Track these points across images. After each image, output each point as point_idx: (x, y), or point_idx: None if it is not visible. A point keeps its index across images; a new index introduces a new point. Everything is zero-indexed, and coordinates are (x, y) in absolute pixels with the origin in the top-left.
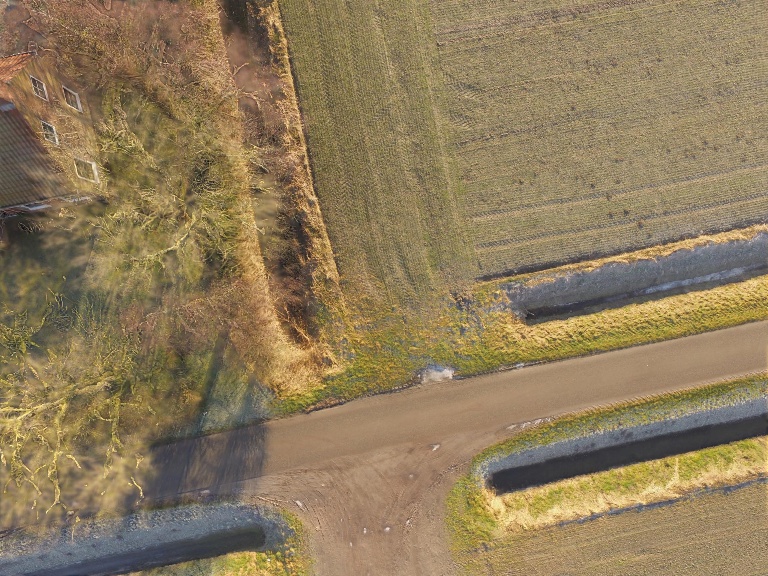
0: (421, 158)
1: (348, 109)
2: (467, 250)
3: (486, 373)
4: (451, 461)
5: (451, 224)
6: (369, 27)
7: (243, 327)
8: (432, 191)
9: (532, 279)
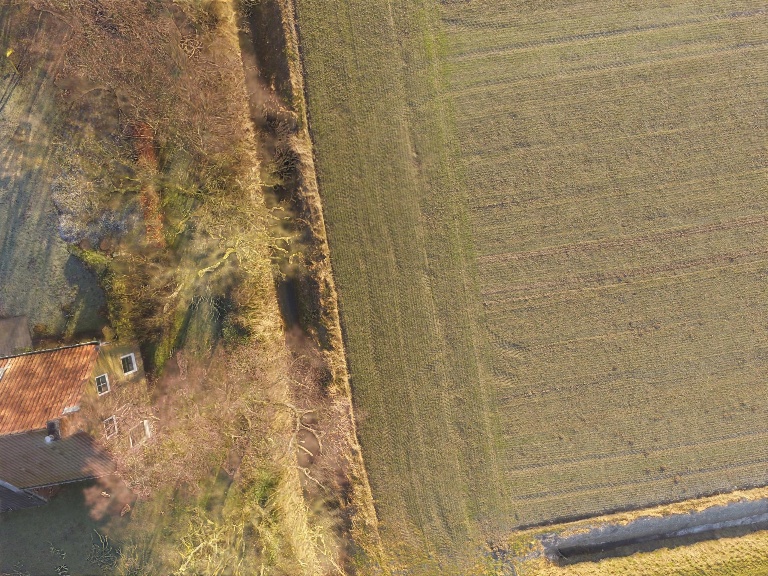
0: (463, 412)
1: (394, 363)
2: (505, 502)
3: None
4: None
5: (490, 477)
6: (418, 286)
7: (282, 568)
8: (473, 445)
9: (567, 530)
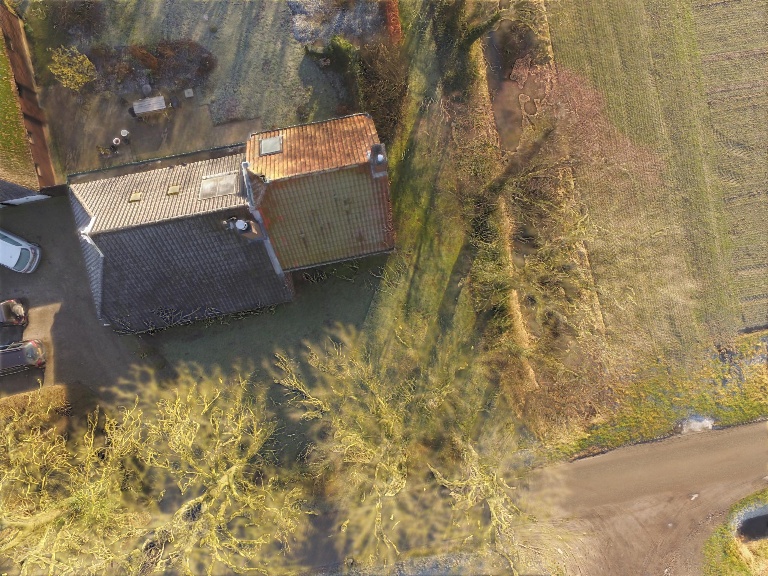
0: (690, 213)
1: None
2: (732, 303)
3: (744, 424)
4: (709, 510)
5: (718, 277)
6: (644, 85)
7: (511, 376)
8: (700, 245)
9: None
